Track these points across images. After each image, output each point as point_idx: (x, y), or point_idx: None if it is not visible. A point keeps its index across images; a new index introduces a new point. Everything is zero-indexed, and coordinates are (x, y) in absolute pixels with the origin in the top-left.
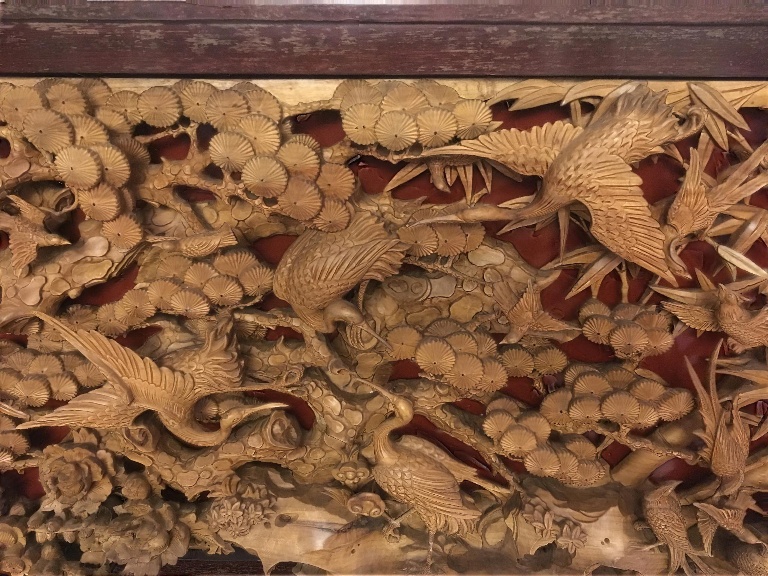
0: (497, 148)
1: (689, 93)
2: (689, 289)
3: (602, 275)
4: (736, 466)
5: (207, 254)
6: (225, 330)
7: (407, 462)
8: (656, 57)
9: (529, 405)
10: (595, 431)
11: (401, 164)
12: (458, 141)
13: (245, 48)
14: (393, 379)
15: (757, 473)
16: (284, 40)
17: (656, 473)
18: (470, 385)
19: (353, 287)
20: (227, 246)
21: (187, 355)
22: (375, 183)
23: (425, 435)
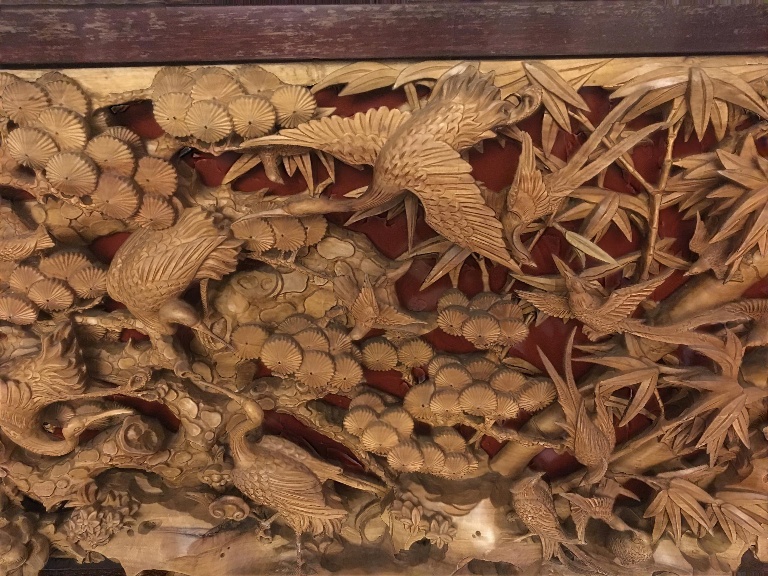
0: (319, 137)
1: (525, 73)
2: (548, 276)
3: (454, 265)
4: (599, 455)
5: (25, 257)
6: (62, 335)
7: (264, 464)
8: (486, 36)
9: (399, 399)
10: (463, 423)
11: (235, 155)
12: (277, 131)
13: (46, 35)
14: (257, 377)
15: (633, 458)
16: (88, 26)
17: (536, 461)
18: (321, 383)
19: (188, 287)
20: (54, 247)
21: (23, 363)
22: (214, 175)
23: (289, 434)
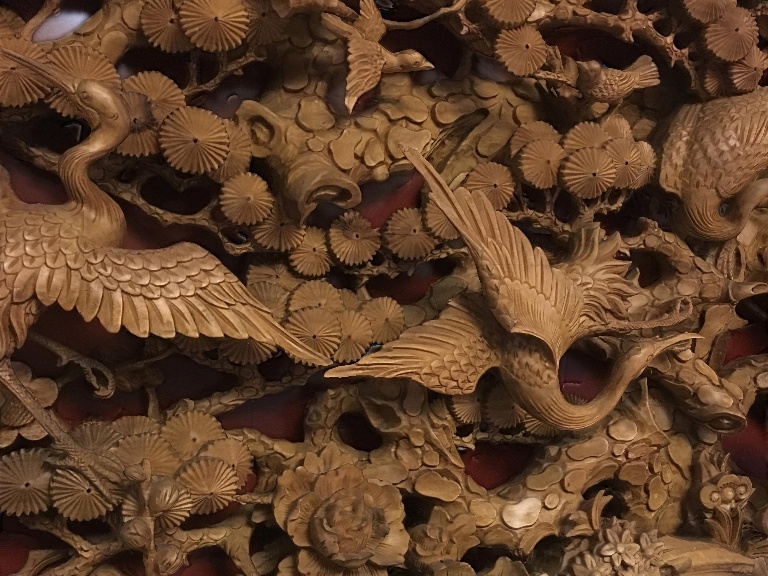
0: None
1: None
2: None
3: None
4: None
5: (620, 97)
6: (599, 235)
7: None
8: None
9: None
10: None
11: None
12: None
13: None
14: (732, 358)
15: None
16: None
17: None
18: None
19: None
20: None
21: (559, 267)
22: None
23: None
